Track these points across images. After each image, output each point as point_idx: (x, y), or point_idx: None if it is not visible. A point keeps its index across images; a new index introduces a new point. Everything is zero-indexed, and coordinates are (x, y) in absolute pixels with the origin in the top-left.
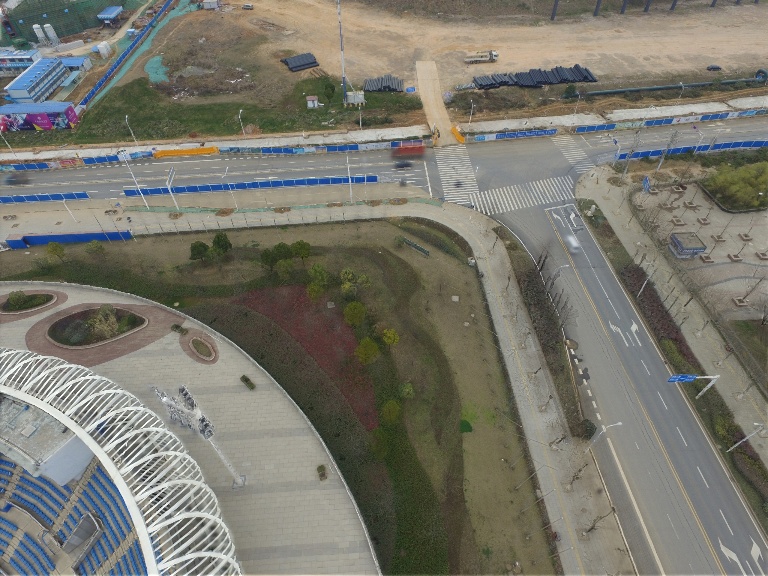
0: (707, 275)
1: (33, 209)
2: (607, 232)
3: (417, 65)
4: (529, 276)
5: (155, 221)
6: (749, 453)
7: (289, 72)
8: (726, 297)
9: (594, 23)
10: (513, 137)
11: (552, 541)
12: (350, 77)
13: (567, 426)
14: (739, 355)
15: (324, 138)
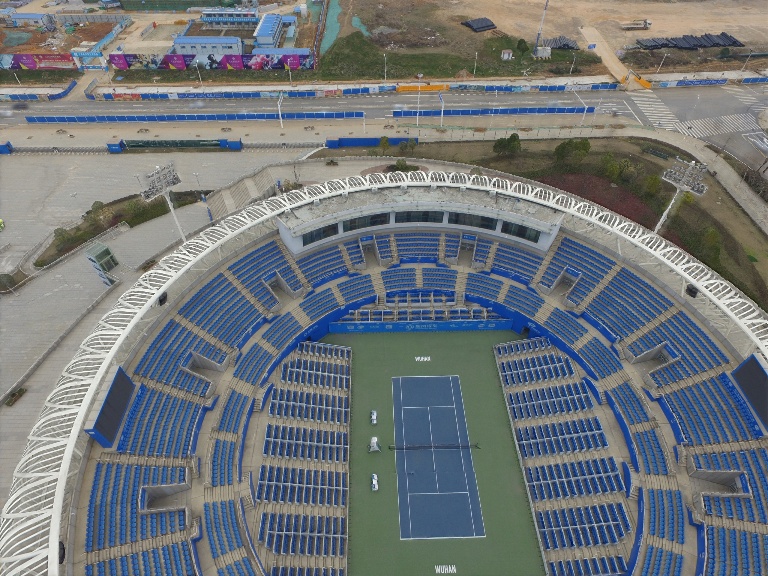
0: None
1: (322, 124)
2: None
3: (581, 30)
4: (753, 175)
5: (428, 134)
6: None
7: (473, 32)
8: None
9: (721, 2)
10: (690, 85)
11: None
12: (528, 37)
13: None
14: None
15: (528, 82)
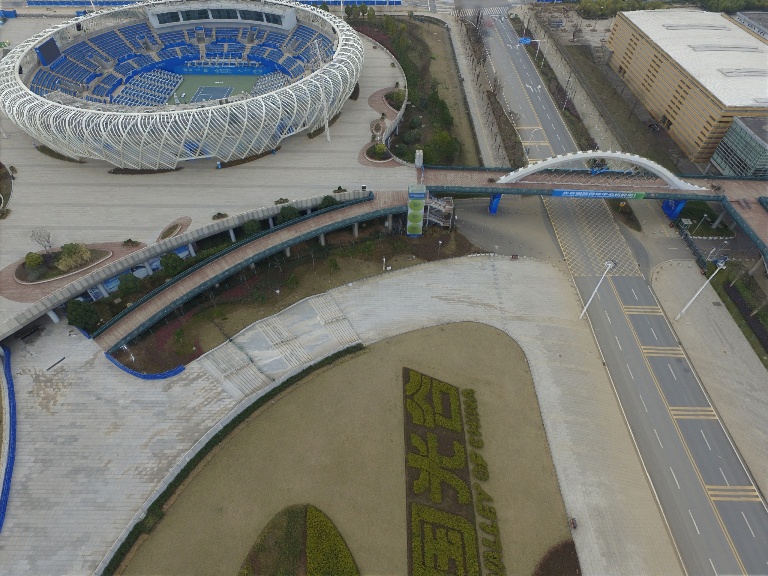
0: None
1: None
2: (518, 22)
3: None
4: None
5: None
6: (548, 67)
7: None
8: (567, 40)
9: None
10: None
11: None
12: None
13: (476, 63)
14: (561, 51)
15: None
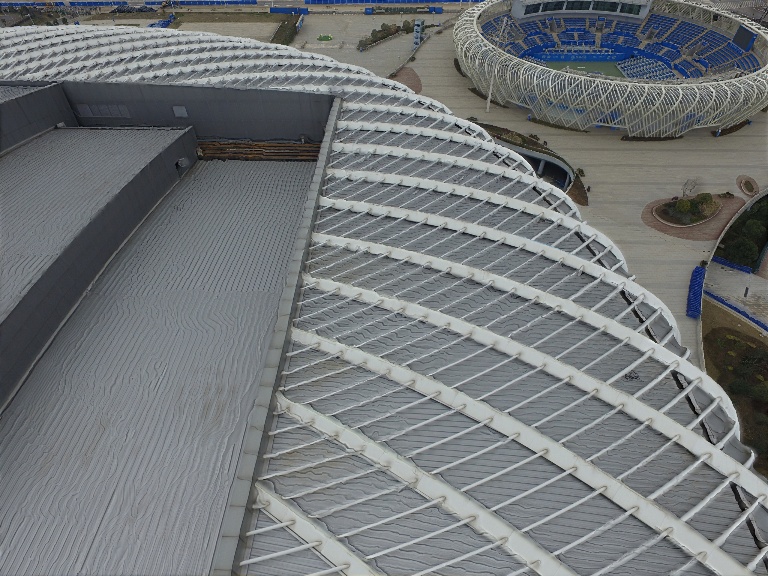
0: None
1: None
2: None
3: None
4: None
5: None
6: None
7: None
8: None
9: None
10: None
11: None
12: None
13: None
14: None
15: None
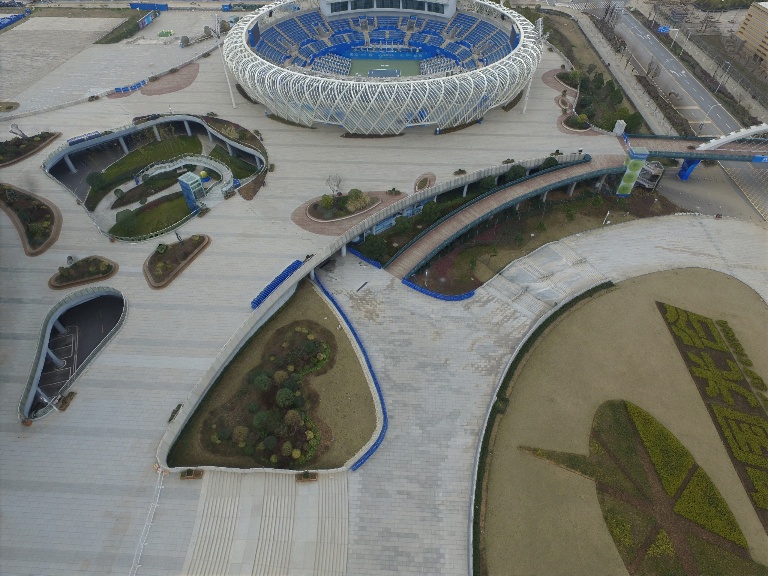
0: (687, 26)
1: None
2: (640, 14)
3: None
4: None
5: None
6: None
7: None
8: (694, 30)
9: None
10: None
11: (607, 66)
12: None
13: (614, 50)
14: None
15: None
